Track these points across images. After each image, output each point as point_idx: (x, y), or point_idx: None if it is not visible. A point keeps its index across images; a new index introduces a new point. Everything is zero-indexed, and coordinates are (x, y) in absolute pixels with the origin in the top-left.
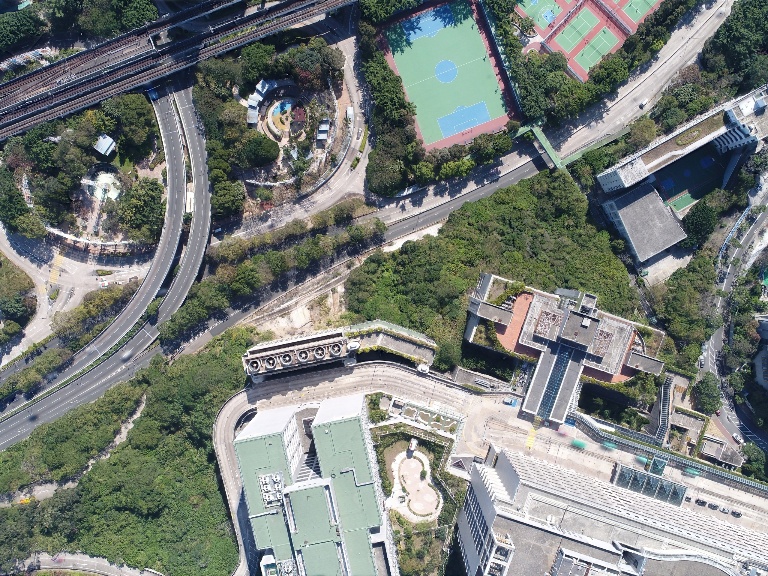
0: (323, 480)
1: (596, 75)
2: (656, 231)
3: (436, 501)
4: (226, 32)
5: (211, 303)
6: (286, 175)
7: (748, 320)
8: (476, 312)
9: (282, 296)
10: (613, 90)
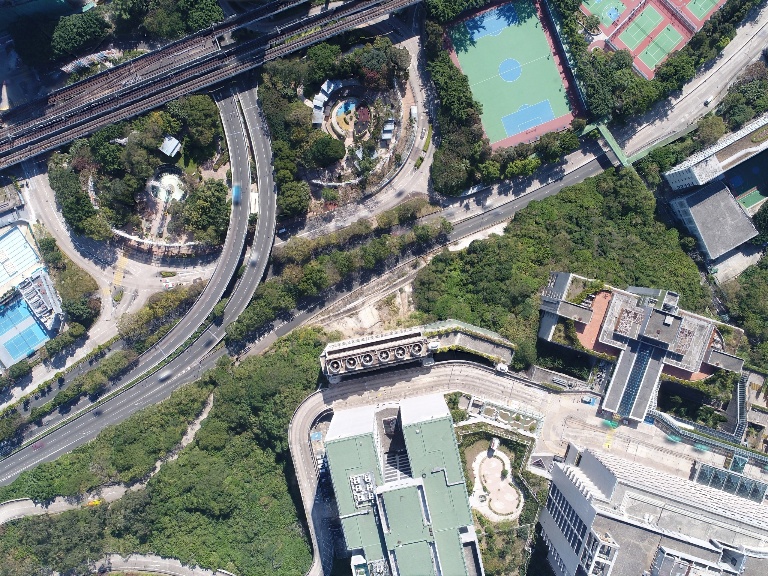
0: (415, 480)
1: (663, 73)
2: (727, 228)
3: (517, 500)
4: (292, 32)
5: (278, 304)
6: (351, 175)
7: None
8: (555, 311)
9: (347, 296)
10: (680, 87)
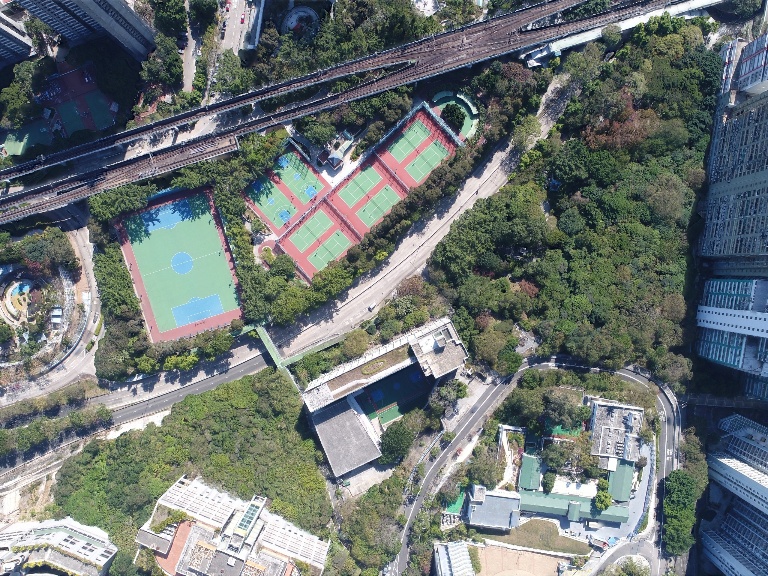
0: None
1: (315, 284)
2: (352, 448)
3: None
4: None
5: None
6: (18, 356)
7: (422, 551)
8: None
9: (10, 472)
10: (333, 298)
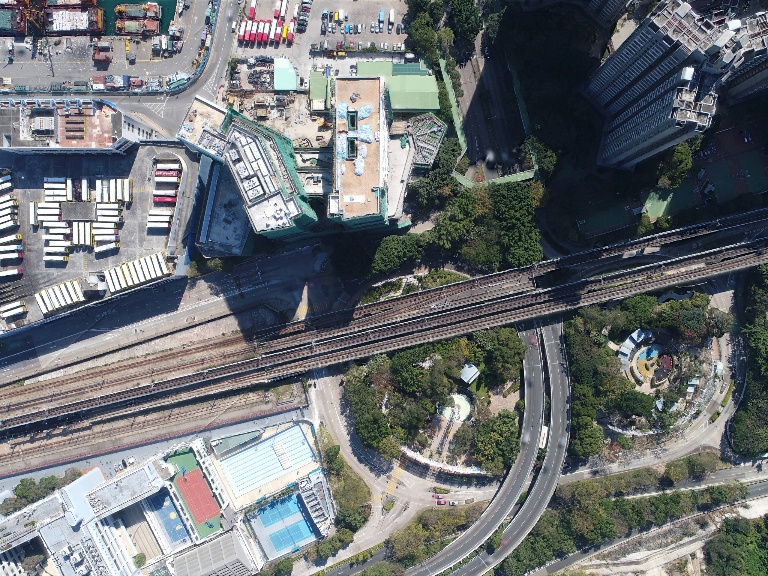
0: None
1: None
2: None
3: None
4: (612, 280)
5: (559, 546)
6: (647, 424)
7: None
8: None
9: (624, 542)
10: None
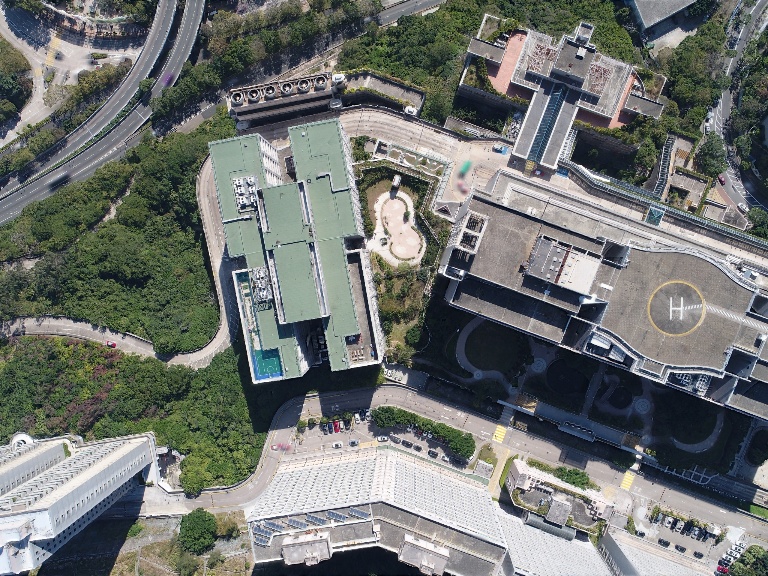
0: None
1: None
2: None
3: (419, 245)
4: None
5: (203, 79)
6: None
7: (758, 78)
8: None
9: (275, 79)
10: None
